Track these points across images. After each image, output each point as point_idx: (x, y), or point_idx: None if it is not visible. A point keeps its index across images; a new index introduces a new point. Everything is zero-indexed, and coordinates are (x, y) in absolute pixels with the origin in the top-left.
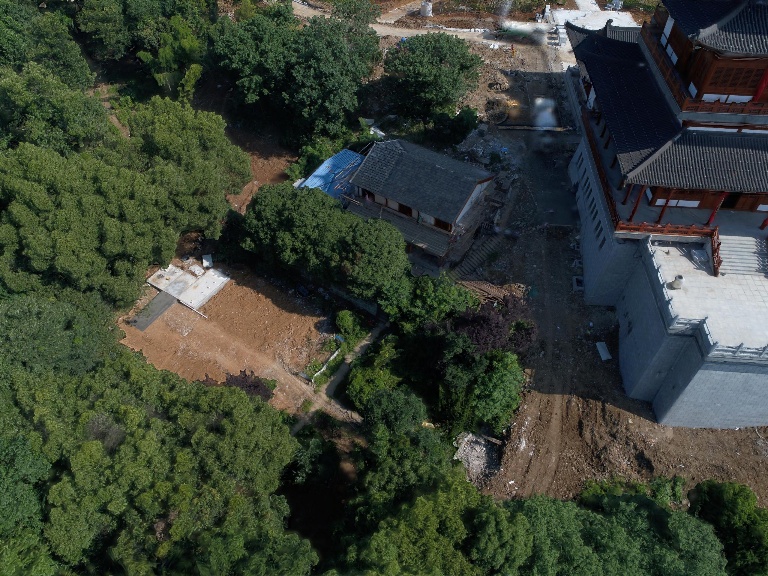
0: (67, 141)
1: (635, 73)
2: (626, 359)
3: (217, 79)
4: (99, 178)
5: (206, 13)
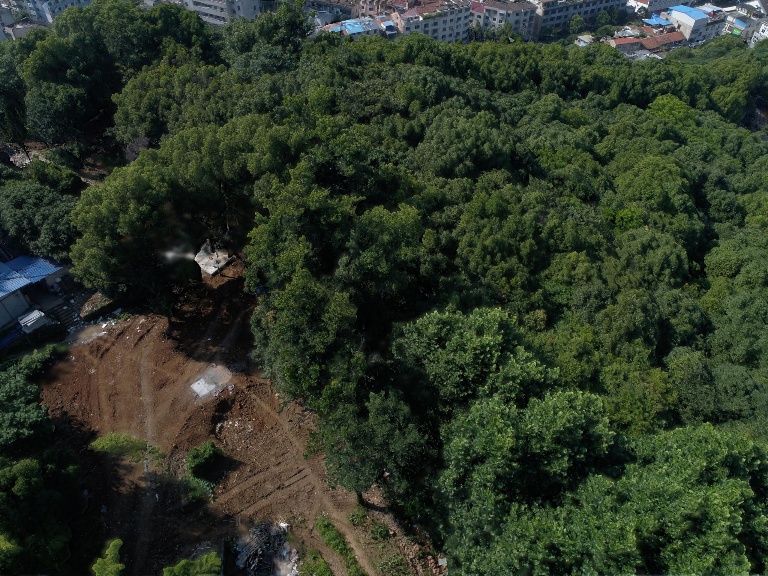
0: None
1: None
2: None
3: None
4: None
5: None
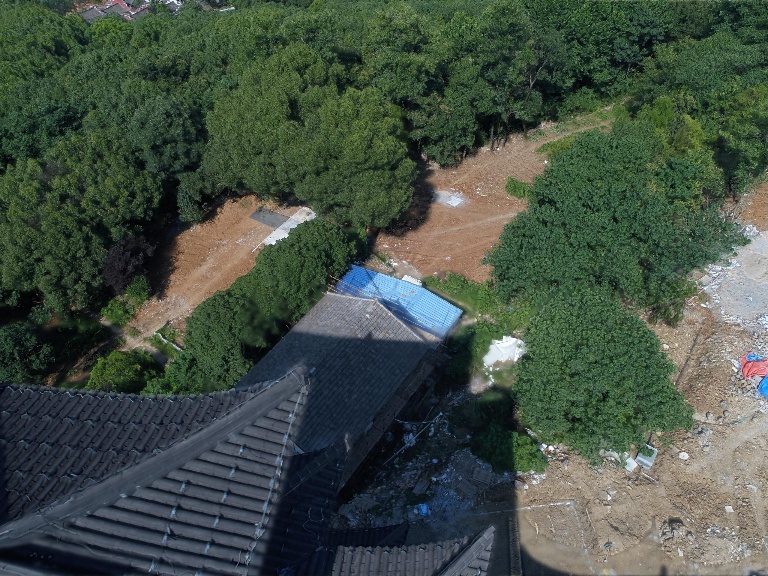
0: None
1: None
2: None
3: None
4: None
5: (734, 129)
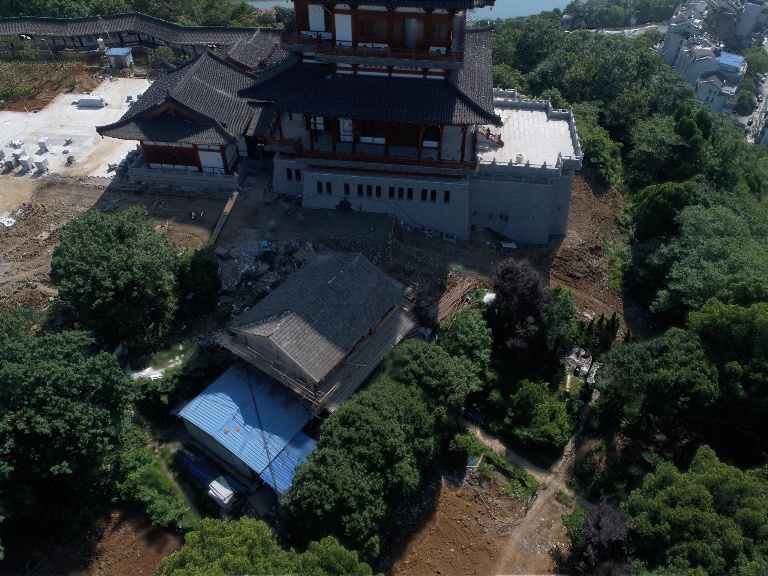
0: None
1: (335, 85)
2: (522, 232)
3: None
4: None
5: None
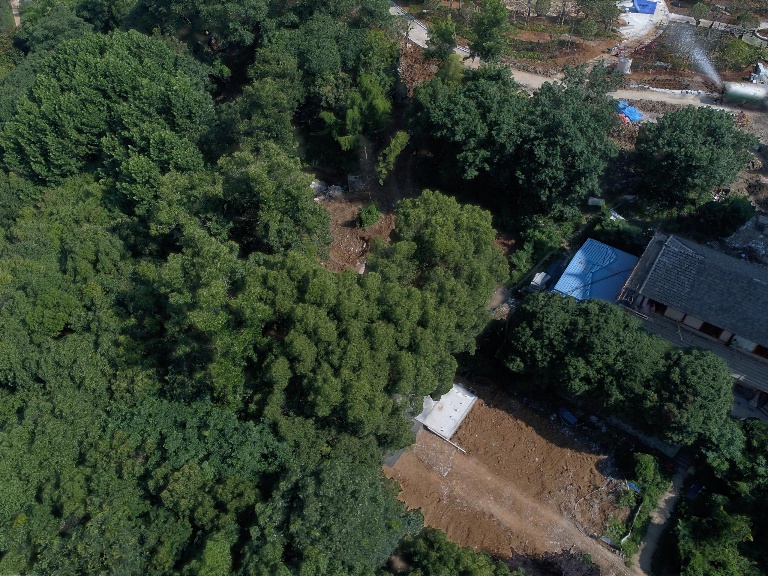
0: (298, 233)
1: None
2: None
3: (418, 147)
4: (389, 301)
5: (388, 68)
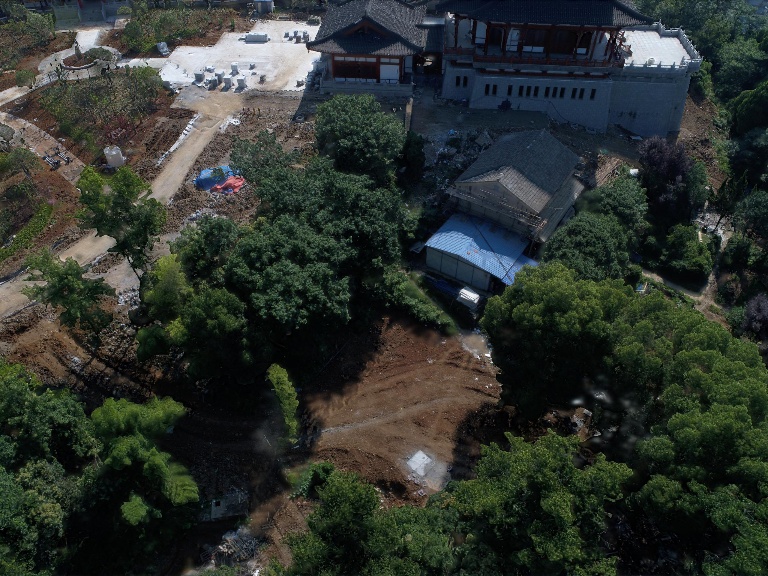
0: None
1: None
2: (646, 128)
3: None
4: None
5: None
